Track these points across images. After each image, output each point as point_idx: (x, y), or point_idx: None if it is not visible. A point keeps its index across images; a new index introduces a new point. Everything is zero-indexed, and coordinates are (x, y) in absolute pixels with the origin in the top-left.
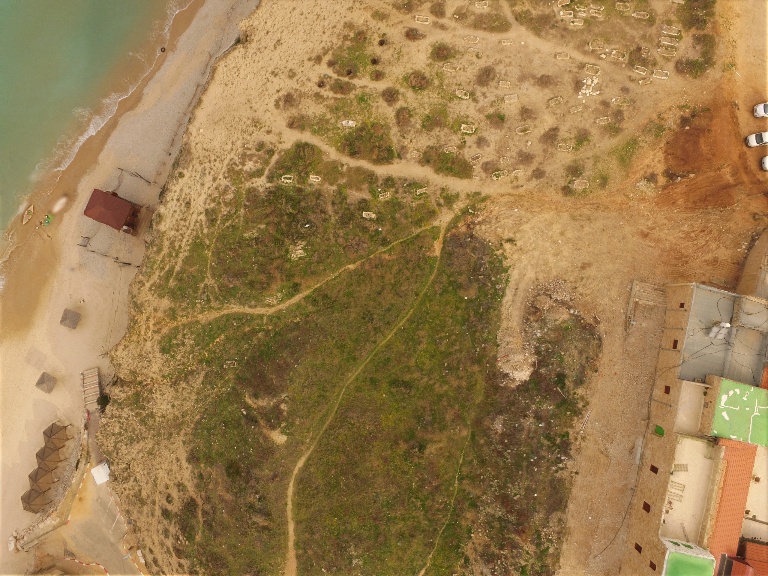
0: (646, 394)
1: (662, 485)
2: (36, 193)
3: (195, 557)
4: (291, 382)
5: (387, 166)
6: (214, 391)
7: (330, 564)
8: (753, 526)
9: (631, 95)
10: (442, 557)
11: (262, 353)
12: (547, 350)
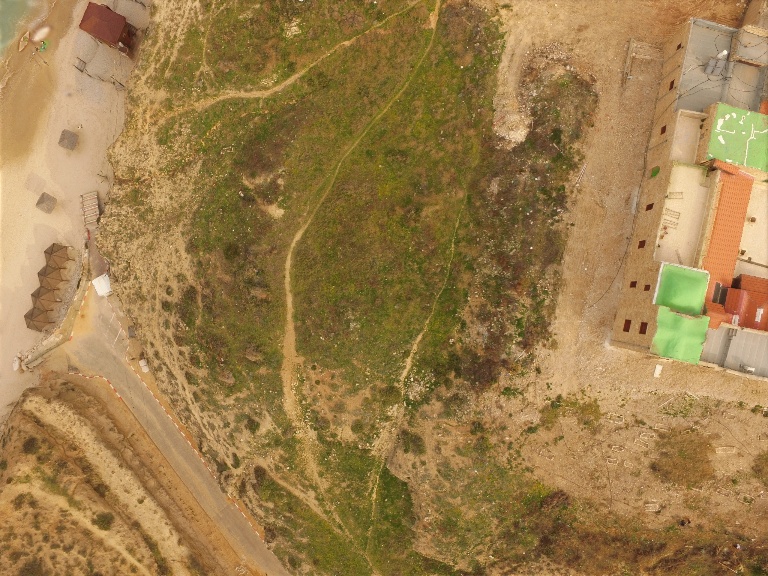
0: (642, 146)
1: (657, 213)
2: (31, 19)
3: (195, 342)
4: (287, 156)
5: None
6: (211, 179)
7: (328, 331)
8: (748, 268)
9: None
10: (439, 322)
11: (258, 136)
12: (543, 108)
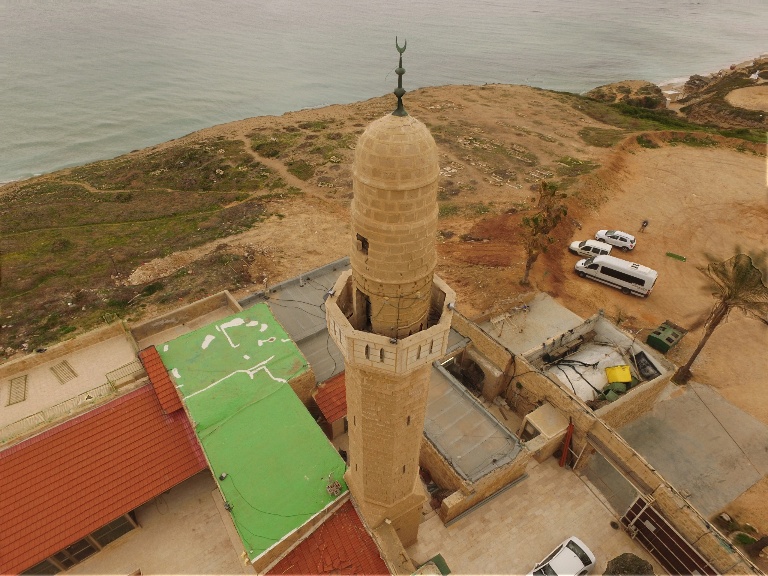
0: None
1: None
2: None
3: None
4: None
5: (265, 158)
6: None
7: None
8: None
9: (477, 186)
10: None
11: None
12: None
